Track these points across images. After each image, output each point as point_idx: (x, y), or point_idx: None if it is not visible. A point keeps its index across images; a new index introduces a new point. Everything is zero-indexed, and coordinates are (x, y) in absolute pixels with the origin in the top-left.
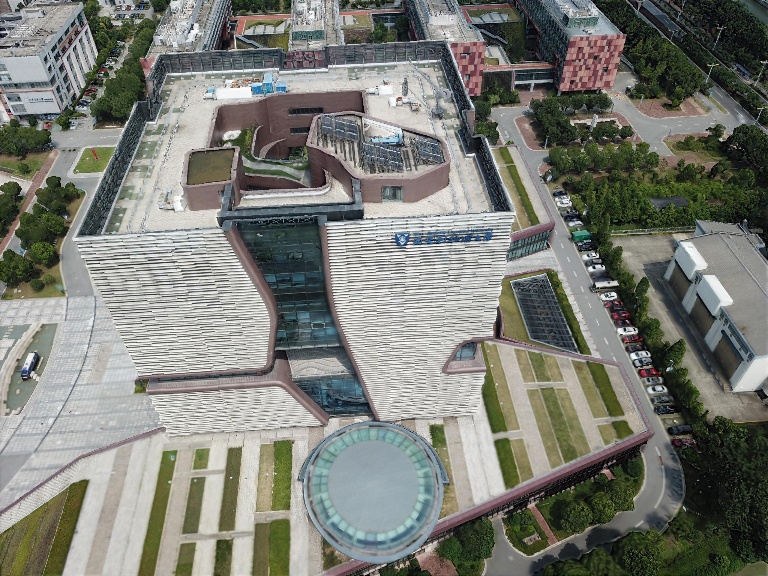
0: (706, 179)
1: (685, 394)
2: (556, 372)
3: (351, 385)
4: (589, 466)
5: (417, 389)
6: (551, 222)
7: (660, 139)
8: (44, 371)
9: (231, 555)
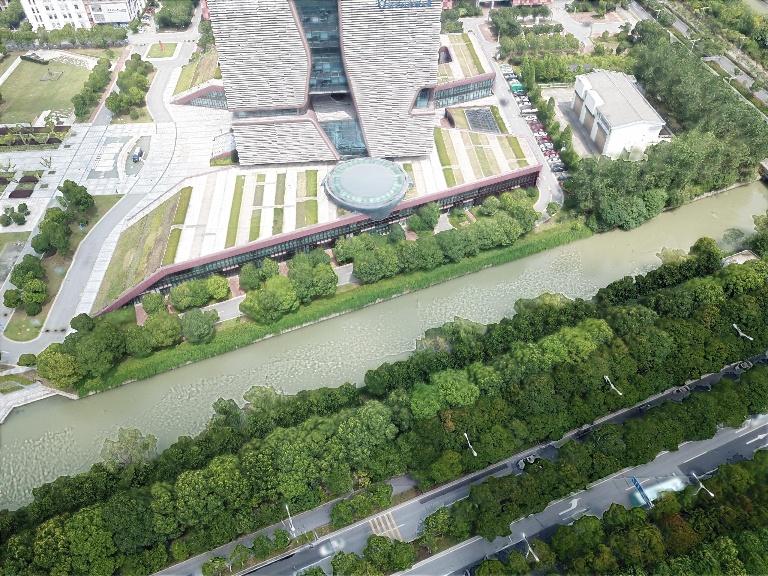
0: (612, 56)
1: (570, 158)
2: (485, 141)
3: (354, 128)
4: (501, 182)
5: (394, 129)
6: (493, 72)
7: (585, 36)
8: (147, 158)
9: (283, 213)
